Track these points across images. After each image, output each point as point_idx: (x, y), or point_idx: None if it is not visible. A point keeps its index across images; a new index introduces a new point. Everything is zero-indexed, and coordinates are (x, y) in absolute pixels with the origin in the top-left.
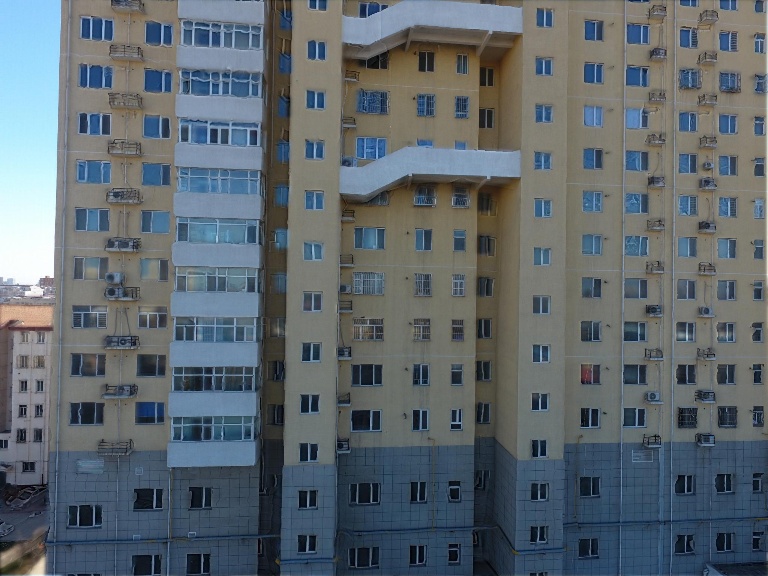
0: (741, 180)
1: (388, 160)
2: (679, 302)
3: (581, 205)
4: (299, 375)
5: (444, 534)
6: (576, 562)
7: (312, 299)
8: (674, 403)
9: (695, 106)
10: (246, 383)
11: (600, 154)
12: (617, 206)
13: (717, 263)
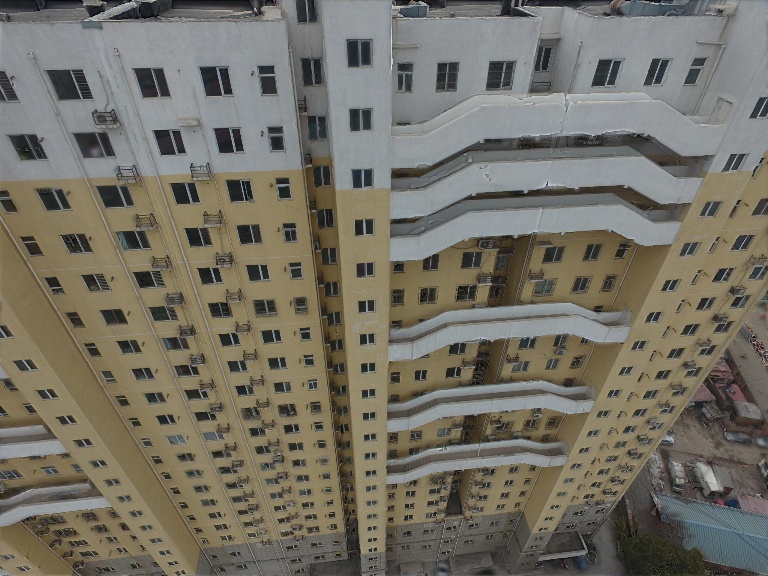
0: (307, 452)
1: (11, 514)
2: (271, 501)
3: (185, 477)
4: (23, 575)
5: (157, 574)
6: (235, 571)
7: (8, 556)
8: (278, 530)
9: (260, 425)
10: (0, 567)
11: (190, 454)
12: (213, 474)
13: (295, 485)
